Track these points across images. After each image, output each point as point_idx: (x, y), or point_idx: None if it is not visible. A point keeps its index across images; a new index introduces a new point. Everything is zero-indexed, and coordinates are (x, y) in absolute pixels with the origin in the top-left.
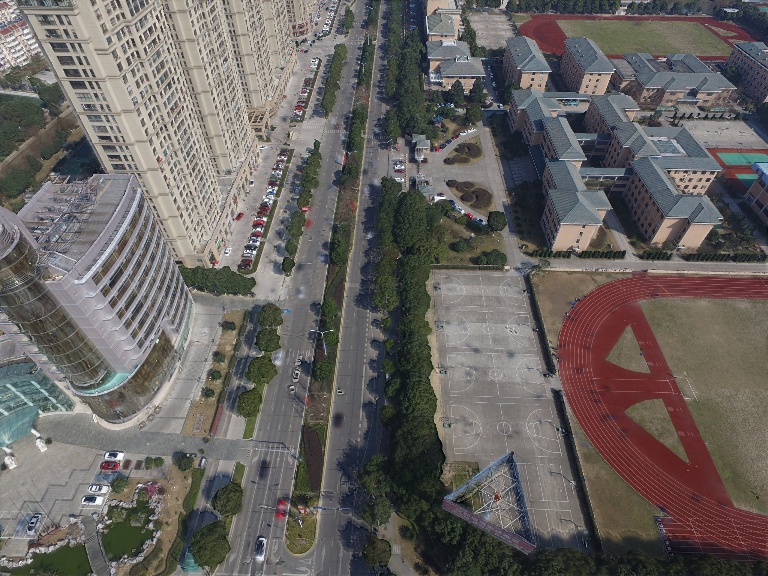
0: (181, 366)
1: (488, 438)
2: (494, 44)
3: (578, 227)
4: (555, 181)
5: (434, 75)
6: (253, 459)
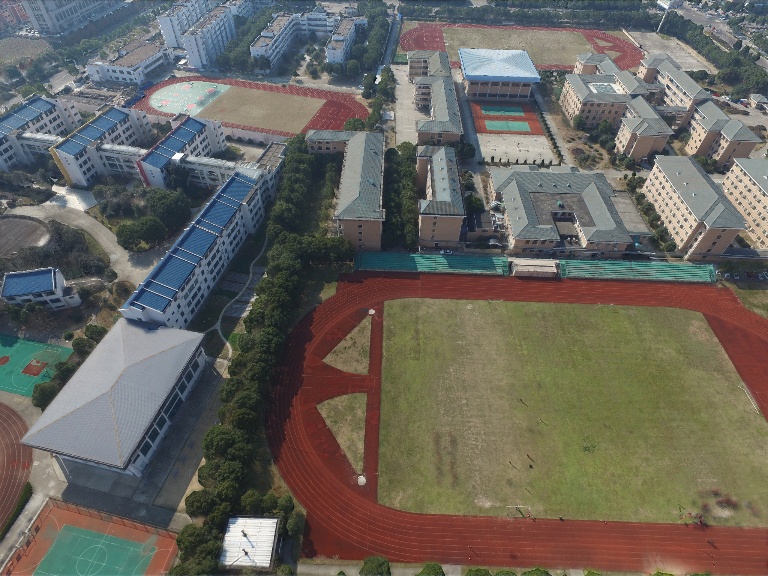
0: None
1: (662, 42)
2: None
3: None
4: None
5: None
6: None
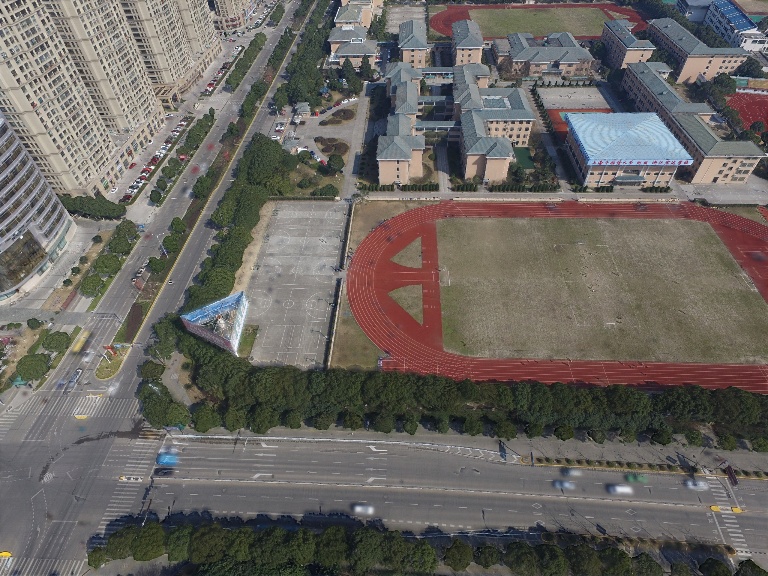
0: (53, 266)
1: (273, 310)
2: None
3: (393, 163)
4: (387, 130)
5: (334, 56)
6: (89, 324)
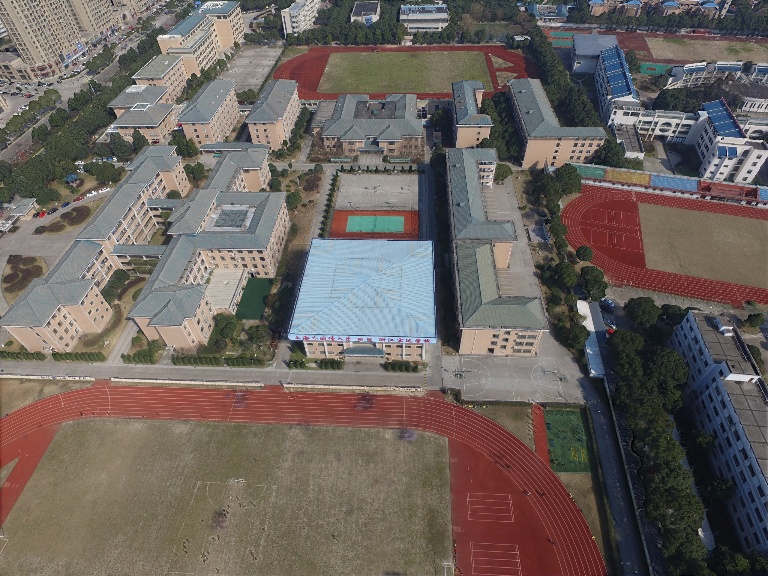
0: None
1: None
2: (237, 83)
3: (25, 329)
4: None
5: None
6: None
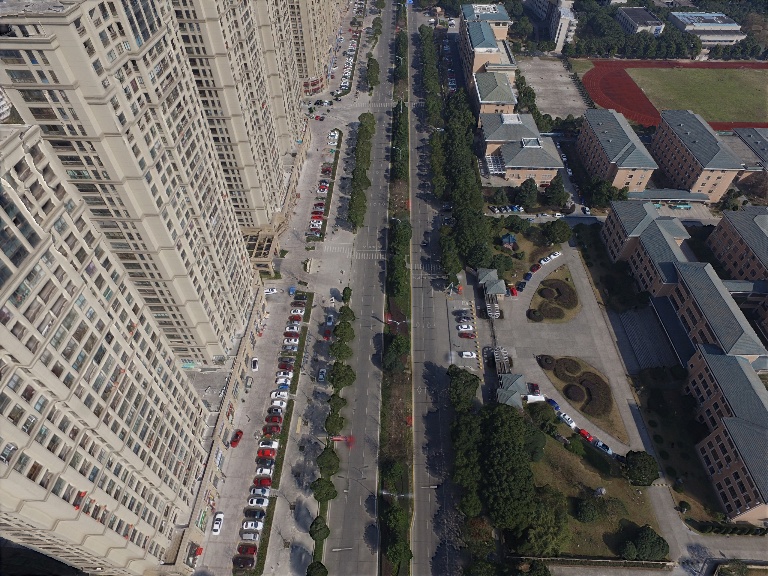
0: None
1: None
2: (556, 106)
3: None
4: (728, 398)
5: (493, 162)
6: None
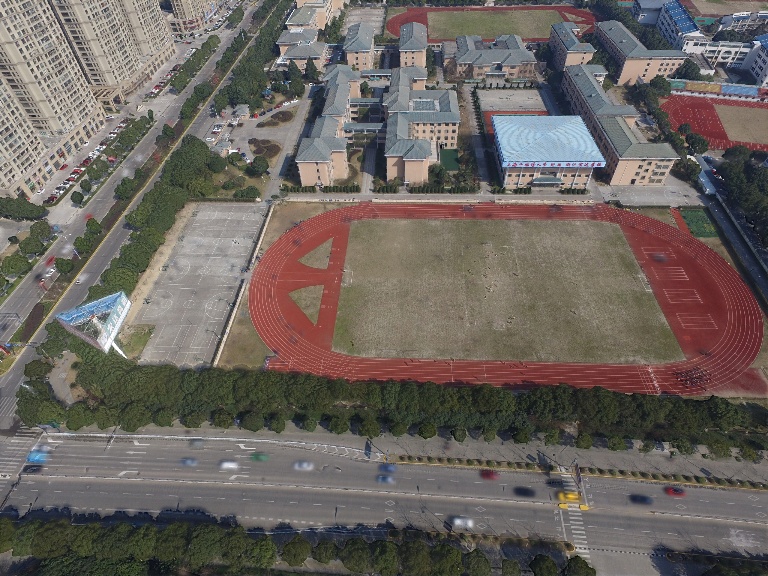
0: None
1: (173, 310)
2: None
3: (312, 165)
4: (312, 132)
5: (282, 58)
6: None
